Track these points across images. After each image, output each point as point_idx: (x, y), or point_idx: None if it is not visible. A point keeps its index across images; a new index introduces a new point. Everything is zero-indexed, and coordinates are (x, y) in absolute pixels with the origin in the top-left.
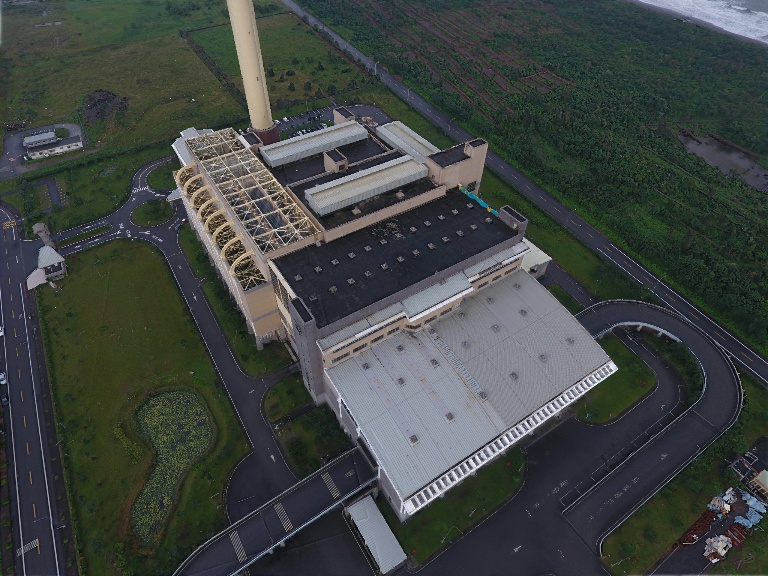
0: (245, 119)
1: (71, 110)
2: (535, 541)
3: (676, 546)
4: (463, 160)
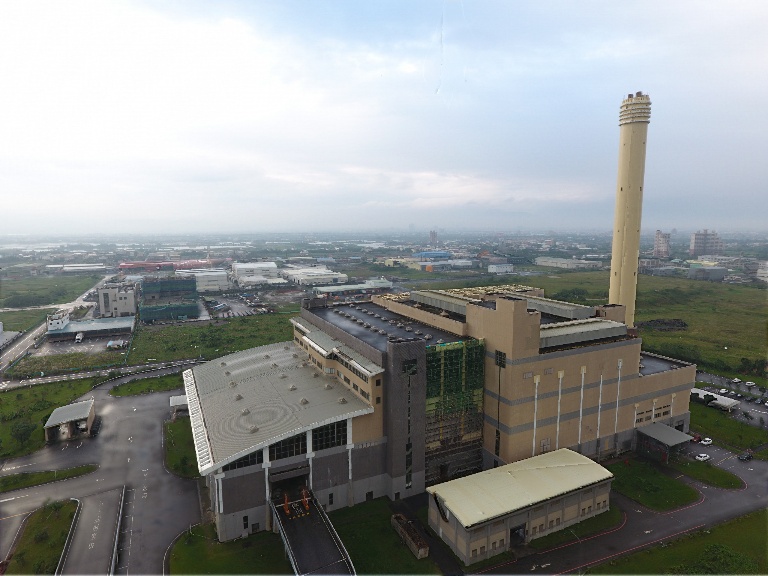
0: (706, 362)
1: (639, 320)
2: (123, 468)
3: (8, 558)
4: (488, 308)
